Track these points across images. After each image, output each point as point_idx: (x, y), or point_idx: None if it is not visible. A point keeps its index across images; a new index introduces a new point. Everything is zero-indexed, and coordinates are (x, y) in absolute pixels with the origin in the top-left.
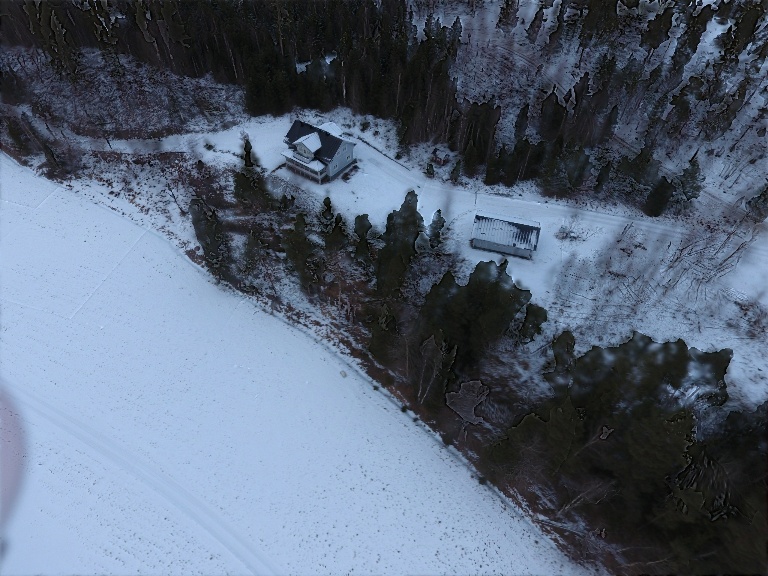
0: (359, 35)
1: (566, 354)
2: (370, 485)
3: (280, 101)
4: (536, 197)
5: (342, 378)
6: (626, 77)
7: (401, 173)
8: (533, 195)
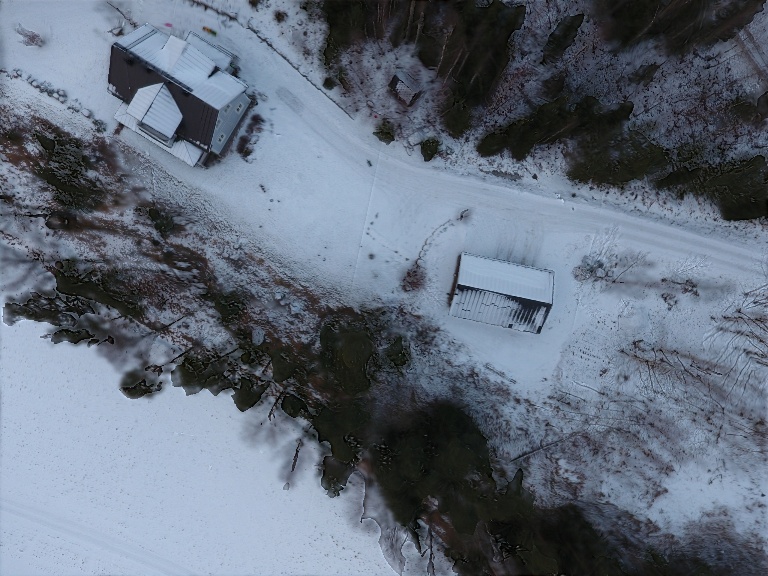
0: None
1: (546, 573)
2: (342, 553)
3: None
4: (559, 182)
5: (299, 447)
6: None
7: (337, 127)
8: (555, 177)
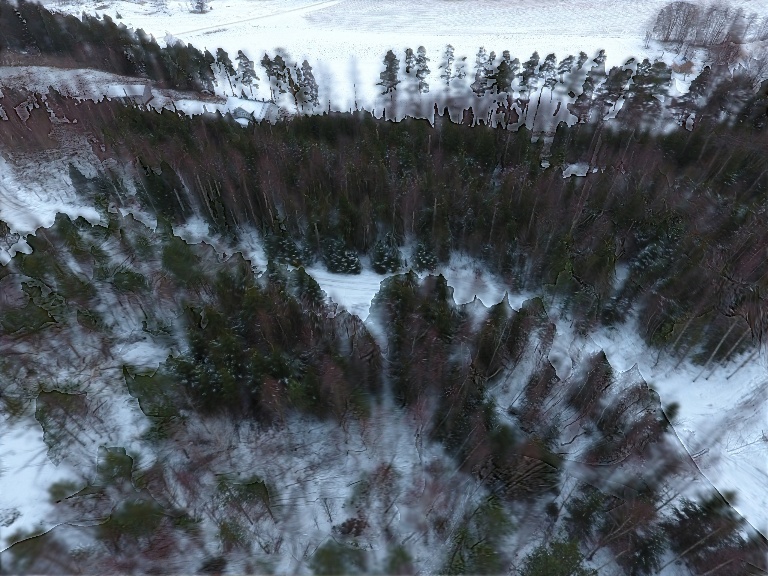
0: None
1: None
2: None
3: None
4: None
5: None
6: None
7: None
8: None
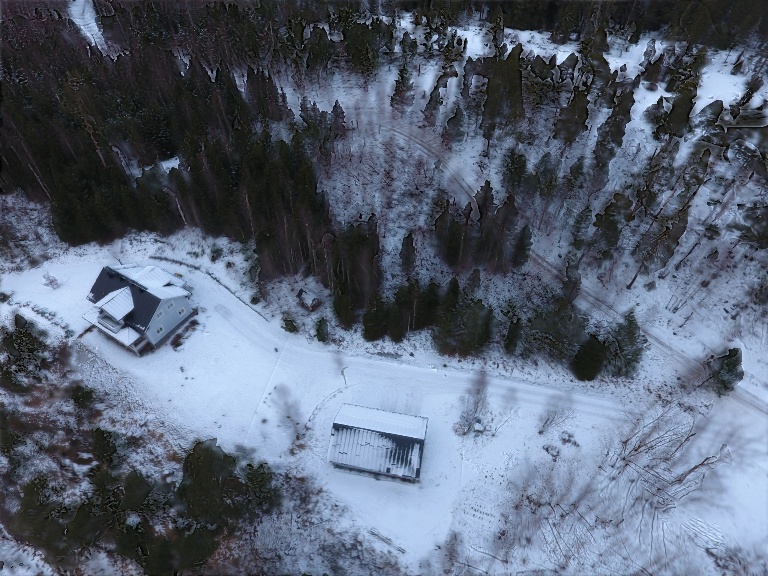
0: (215, 128)
1: None
2: None
3: (104, 227)
4: (432, 357)
5: None
6: (539, 181)
7: (255, 327)
8: (428, 354)
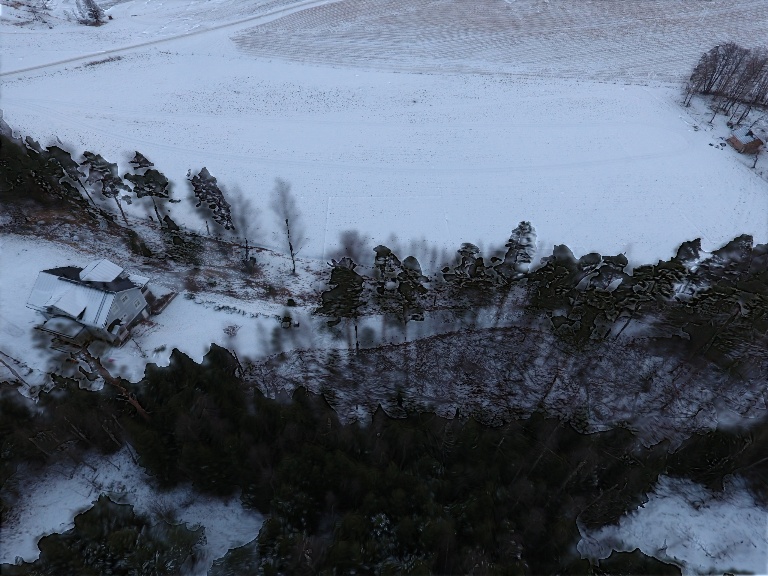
0: None
1: None
2: None
3: None
4: None
5: (104, 198)
6: None
7: None
8: None
